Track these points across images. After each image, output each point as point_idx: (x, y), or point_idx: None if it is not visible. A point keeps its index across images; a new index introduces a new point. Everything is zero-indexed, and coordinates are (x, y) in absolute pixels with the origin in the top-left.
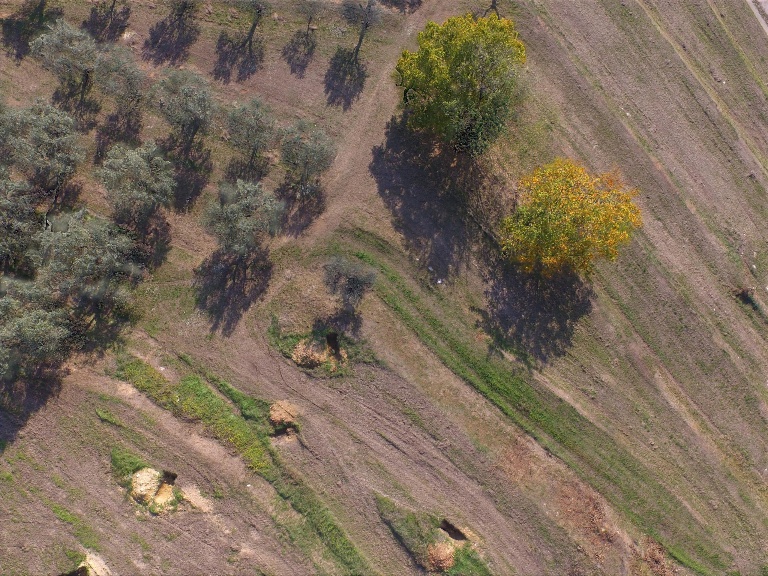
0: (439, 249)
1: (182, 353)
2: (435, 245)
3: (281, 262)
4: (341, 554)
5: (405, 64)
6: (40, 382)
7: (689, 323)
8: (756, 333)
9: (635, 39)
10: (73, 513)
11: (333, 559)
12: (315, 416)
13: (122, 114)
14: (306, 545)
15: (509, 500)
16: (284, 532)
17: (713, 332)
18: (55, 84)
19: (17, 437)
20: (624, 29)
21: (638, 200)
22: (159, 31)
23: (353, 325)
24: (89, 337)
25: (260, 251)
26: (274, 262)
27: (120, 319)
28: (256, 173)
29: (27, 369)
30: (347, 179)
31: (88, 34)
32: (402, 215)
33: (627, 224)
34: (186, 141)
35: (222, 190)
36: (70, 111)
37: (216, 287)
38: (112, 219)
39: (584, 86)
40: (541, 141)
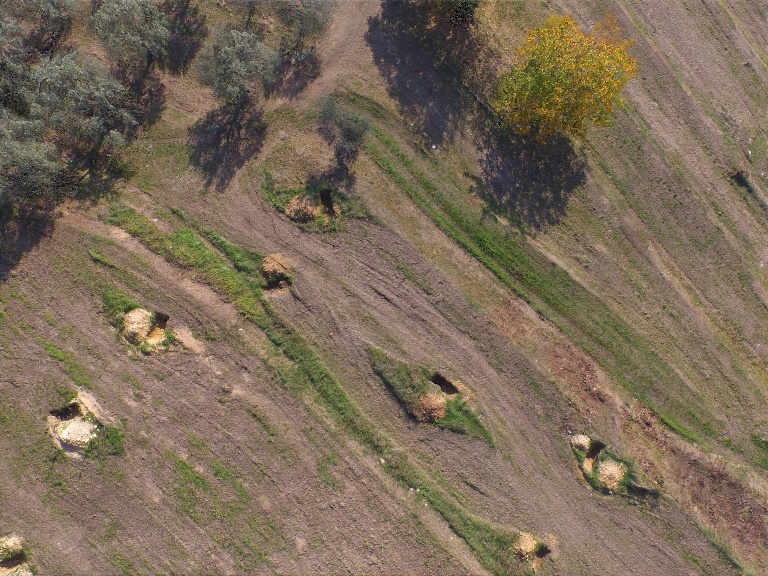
0: (434, 117)
1: (175, 207)
2: (430, 113)
3: (275, 123)
4: (332, 400)
5: None
6: (33, 223)
7: (683, 200)
8: (751, 216)
9: None
10: (65, 351)
11: (324, 404)
12: (308, 269)
13: None
14: (297, 388)
15: (501, 355)
16: (275, 374)
17: (707, 210)
18: None
19: (9, 276)
20: None
21: (634, 81)
22: None
23: (347, 182)
24: (82, 187)
25: (254, 112)
26: (268, 123)
27: (114, 175)
28: (251, 39)
29: (20, 210)
30: (342, 47)
31: None
32: (397, 83)
33: (623, 102)
34: (181, 7)
35: (217, 53)
36: None
37: (210, 145)
38: (107, 80)
39: None
40: (537, 18)
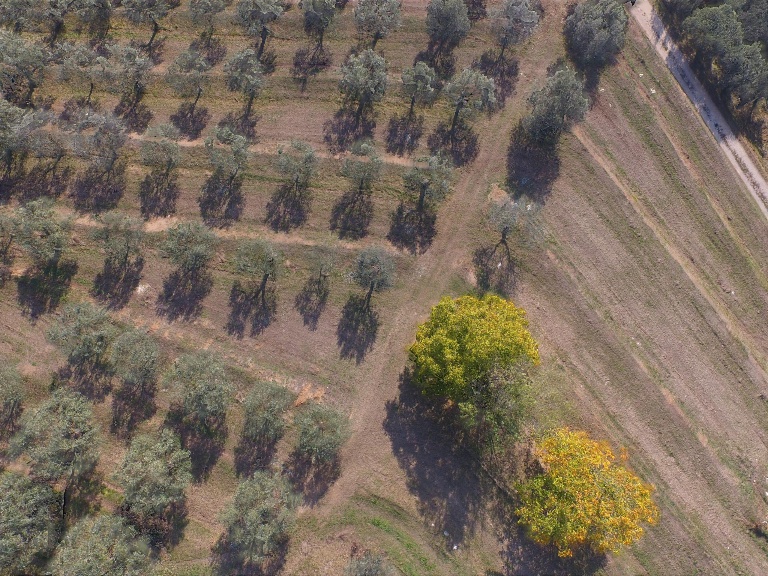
0: (454, 509)
1: None
2: (450, 505)
3: (297, 534)
4: None
5: (419, 349)
6: None
7: (703, 567)
8: None
9: (644, 261)
10: None
11: None
12: None
13: (137, 376)
14: None
15: None
16: None
17: (727, 573)
18: (70, 345)
19: None
20: (633, 251)
21: (650, 436)
22: (173, 283)
23: None
24: None
25: (276, 524)
26: (291, 535)
27: None
28: (271, 436)
29: None
30: (361, 438)
31: (102, 288)
32: (417, 475)
33: (640, 465)
34: (201, 404)
35: (238, 458)
36: (86, 374)
37: (233, 565)
38: None
39: (594, 320)
40: (553, 383)
